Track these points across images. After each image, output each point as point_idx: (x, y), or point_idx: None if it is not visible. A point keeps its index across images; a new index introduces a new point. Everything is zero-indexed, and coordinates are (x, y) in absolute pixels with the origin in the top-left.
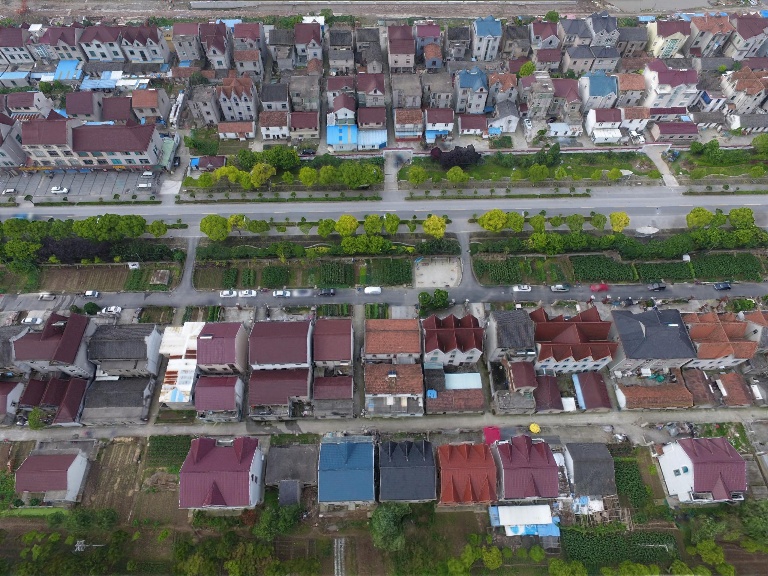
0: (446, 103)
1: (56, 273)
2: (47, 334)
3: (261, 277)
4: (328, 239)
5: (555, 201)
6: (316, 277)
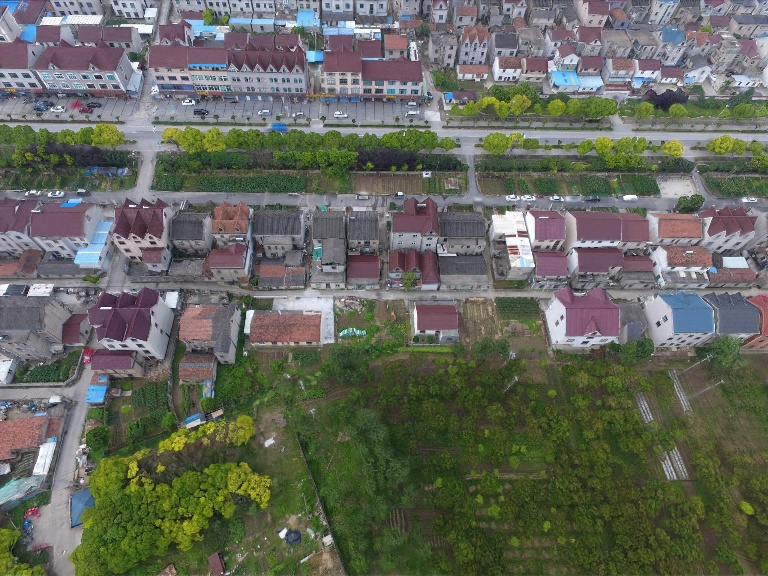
0: (648, 55)
1: (362, 179)
2: (415, 212)
3: (534, 187)
4: (582, 158)
5: (755, 136)
6: (578, 188)
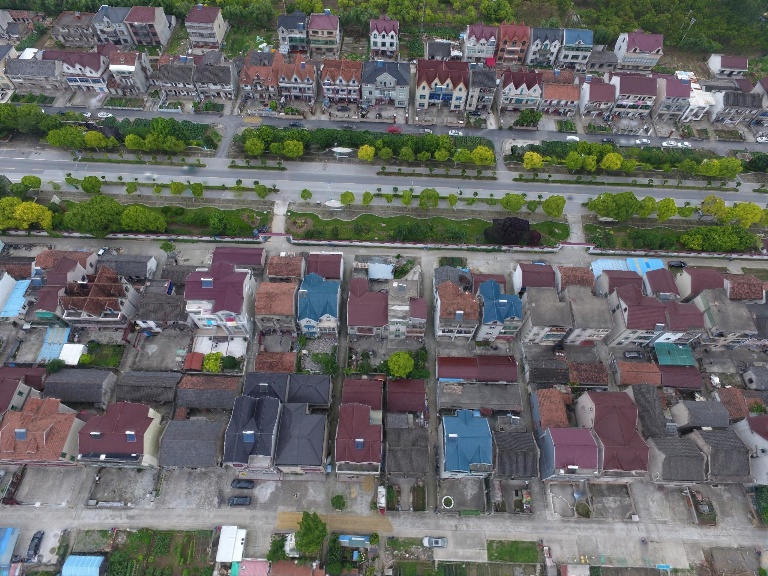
0: None
1: None
2: None
3: None
4: (622, 172)
5: None
6: (620, 153)
